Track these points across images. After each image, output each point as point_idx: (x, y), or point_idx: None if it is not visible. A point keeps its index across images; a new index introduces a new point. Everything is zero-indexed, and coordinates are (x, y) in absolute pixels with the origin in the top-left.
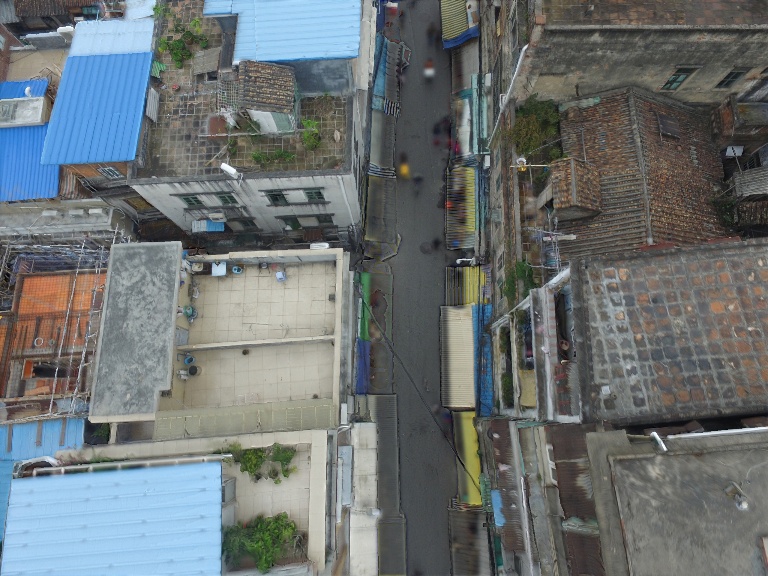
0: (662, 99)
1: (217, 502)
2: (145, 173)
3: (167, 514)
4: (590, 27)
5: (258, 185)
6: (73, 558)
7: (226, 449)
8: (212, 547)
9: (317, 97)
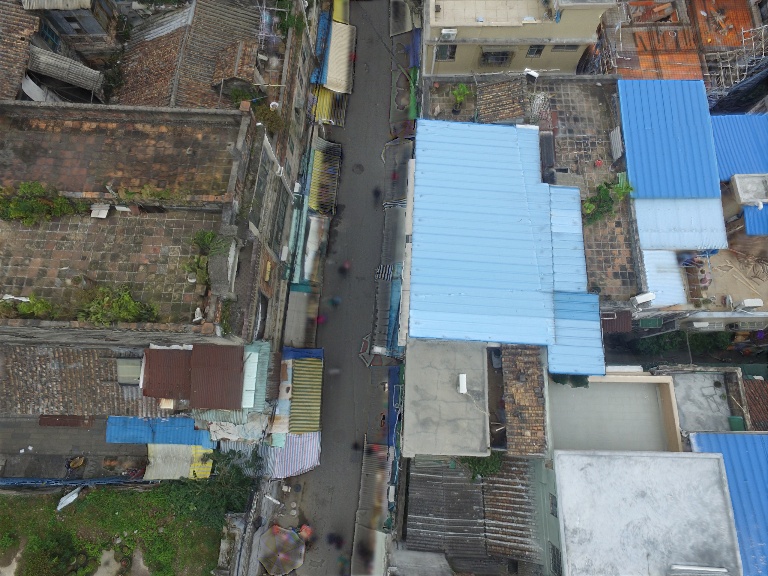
0: None
1: None
2: (609, 90)
3: None
4: (200, 110)
5: None
6: None
7: None
8: None
9: None
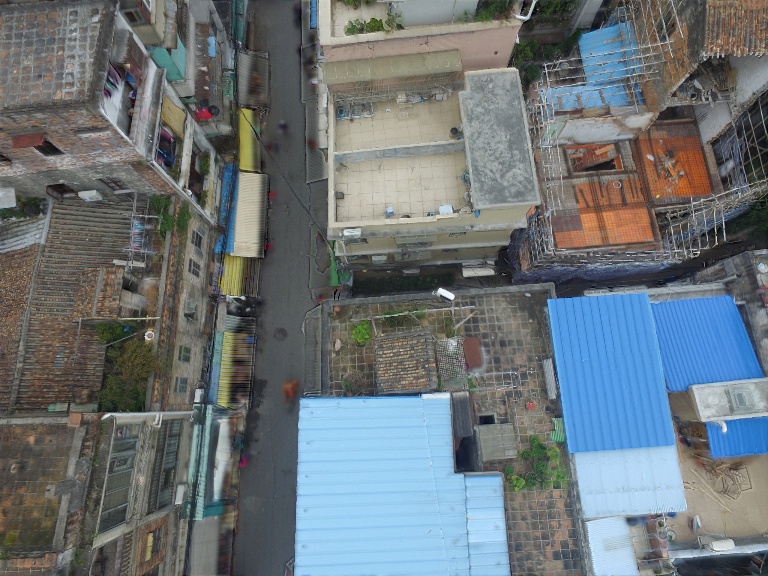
0: None
1: None
2: (540, 301)
3: None
4: (22, 420)
5: None
6: None
7: None
8: None
9: None
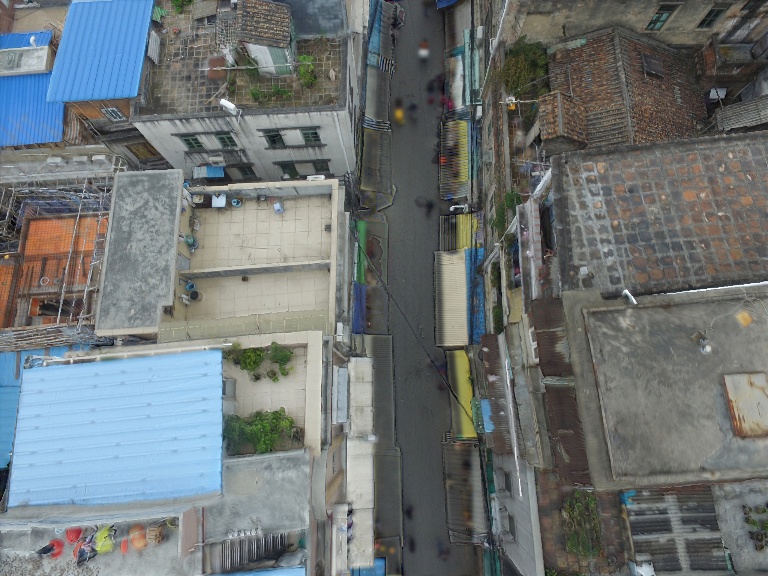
0: (647, 40)
1: (218, 385)
2: (147, 112)
3: (171, 397)
4: None
5: (256, 123)
6: (82, 438)
7: (226, 349)
8: (213, 425)
9: (313, 39)
